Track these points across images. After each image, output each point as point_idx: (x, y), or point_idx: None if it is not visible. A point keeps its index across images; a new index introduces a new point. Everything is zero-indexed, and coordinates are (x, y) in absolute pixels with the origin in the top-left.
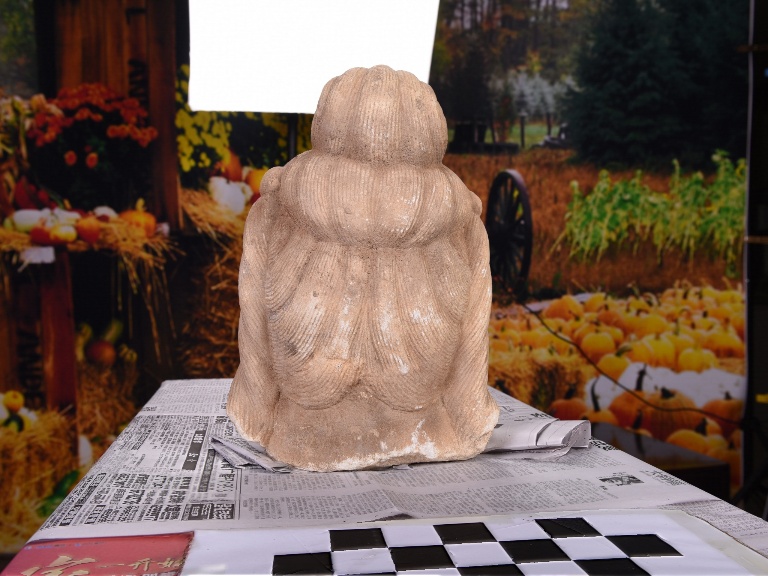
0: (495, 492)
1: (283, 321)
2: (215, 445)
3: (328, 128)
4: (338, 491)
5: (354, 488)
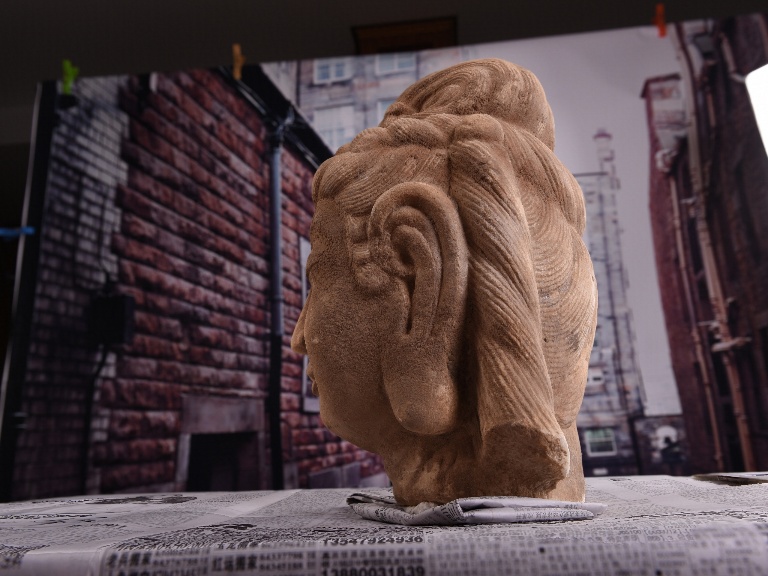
0: (651, 491)
1: (568, 305)
2: (490, 511)
3: (541, 109)
4: (678, 503)
5: (664, 501)
